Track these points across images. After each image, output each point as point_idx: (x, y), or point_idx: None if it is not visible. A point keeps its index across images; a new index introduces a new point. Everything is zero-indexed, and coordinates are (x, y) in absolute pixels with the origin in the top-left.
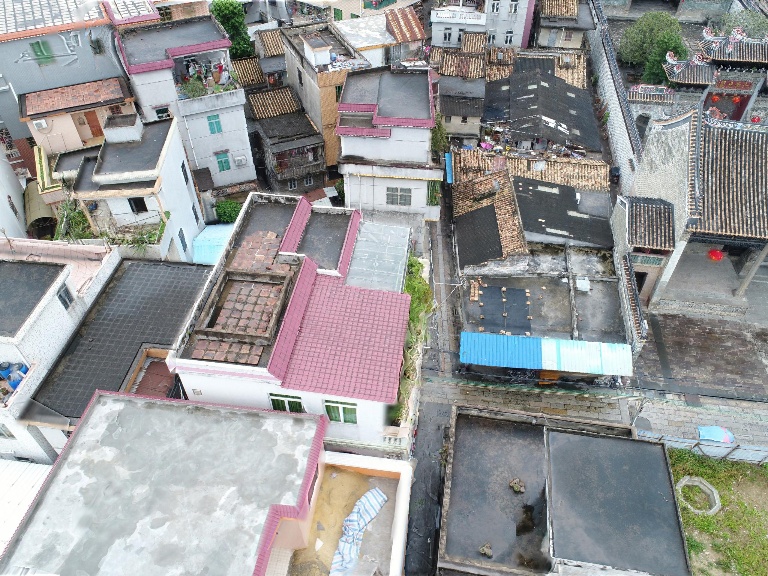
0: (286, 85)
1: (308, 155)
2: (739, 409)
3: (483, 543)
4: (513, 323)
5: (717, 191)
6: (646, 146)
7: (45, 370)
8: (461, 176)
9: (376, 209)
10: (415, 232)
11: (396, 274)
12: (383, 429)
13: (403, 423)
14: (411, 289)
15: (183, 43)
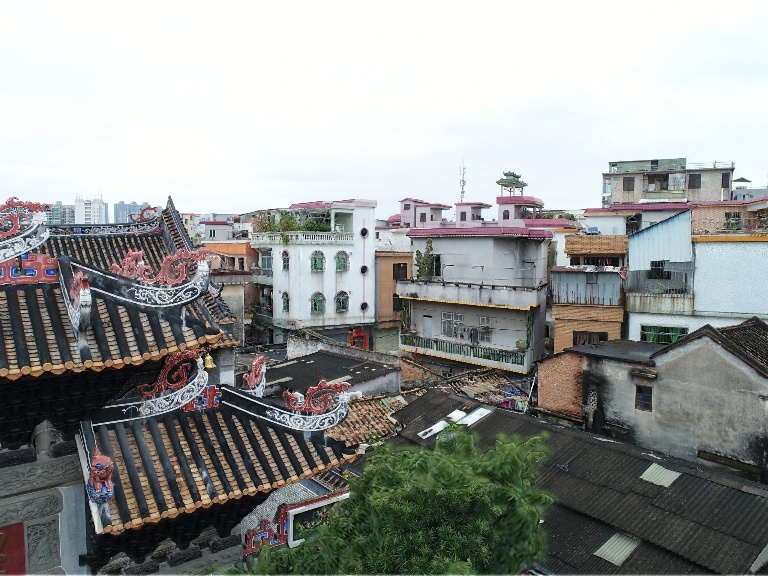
0: None
1: None
2: None
3: None
4: None
5: None
6: None
7: (390, 249)
8: None
9: None
10: None
11: None
12: None
13: None
14: None
15: None
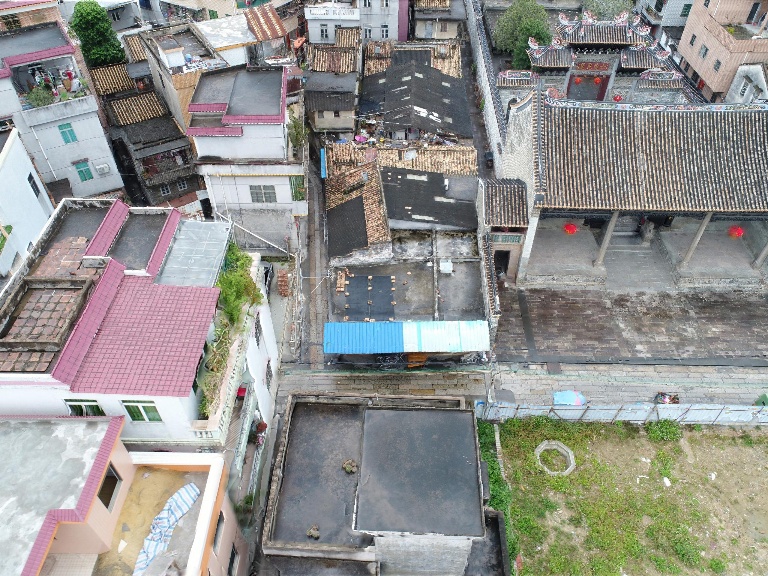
0: (151, 89)
1: (175, 159)
2: (596, 373)
3: (312, 526)
4: (377, 310)
5: (561, 167)
6: (507, 129)
7: None
8: (334, 170)
9: (243, 208)
10: (286, 228)
11: (211, 269)
12: (190, 424)
13: (212, 416)
14: (227, 283)
15: (23, 51)
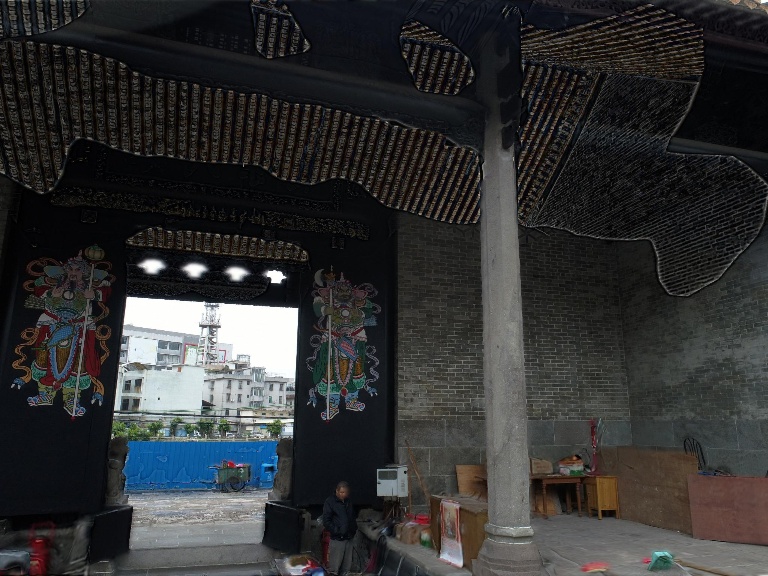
0: None
1: None
2: None
3: None
4: None
5: None
6: None
7: None
8: None
9: None
10: None
11: None
12: None
13: None
14: None
15: None
